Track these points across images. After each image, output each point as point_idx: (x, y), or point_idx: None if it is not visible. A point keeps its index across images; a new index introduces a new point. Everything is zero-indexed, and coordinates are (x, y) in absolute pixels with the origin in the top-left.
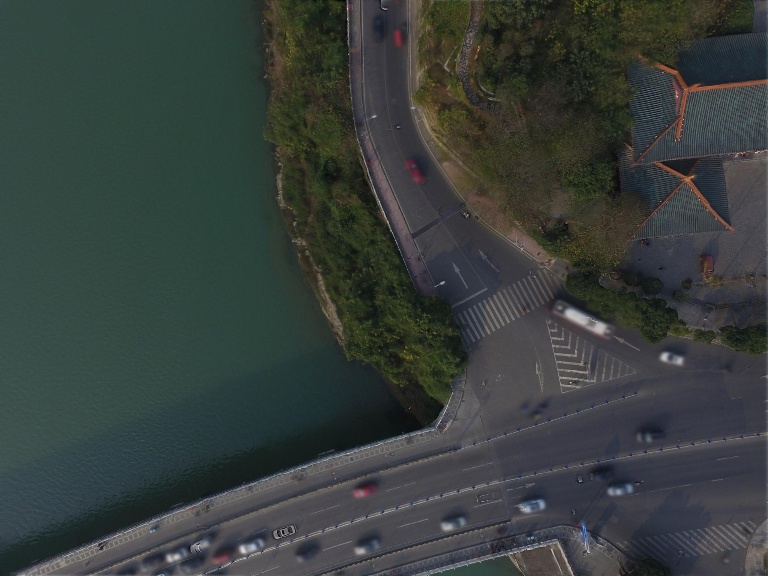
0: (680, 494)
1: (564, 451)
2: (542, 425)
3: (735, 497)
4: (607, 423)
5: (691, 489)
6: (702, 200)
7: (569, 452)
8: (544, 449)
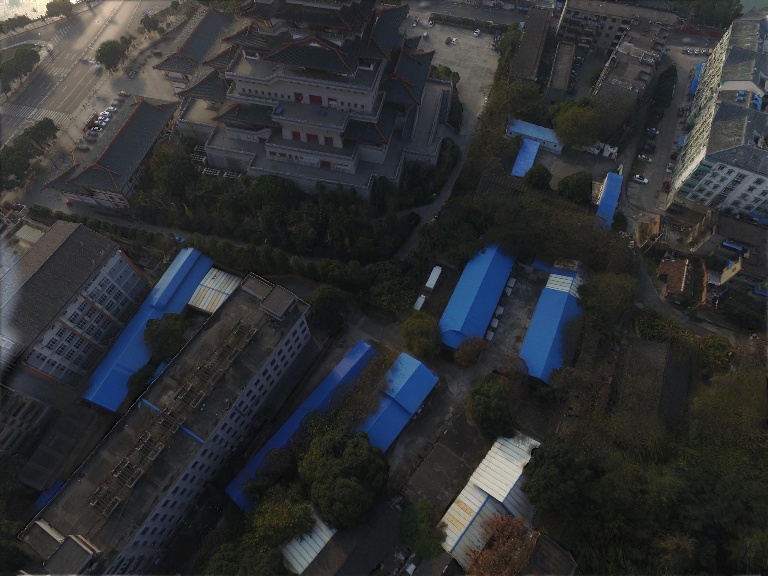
0: (84, 30)
1: (125, 7)
2: (138, 4)
3: (69, 42)
4: (125, 19)
5: (83, 33)
6: (178, 26)
7: (123, 8)
8: (130, 4)
